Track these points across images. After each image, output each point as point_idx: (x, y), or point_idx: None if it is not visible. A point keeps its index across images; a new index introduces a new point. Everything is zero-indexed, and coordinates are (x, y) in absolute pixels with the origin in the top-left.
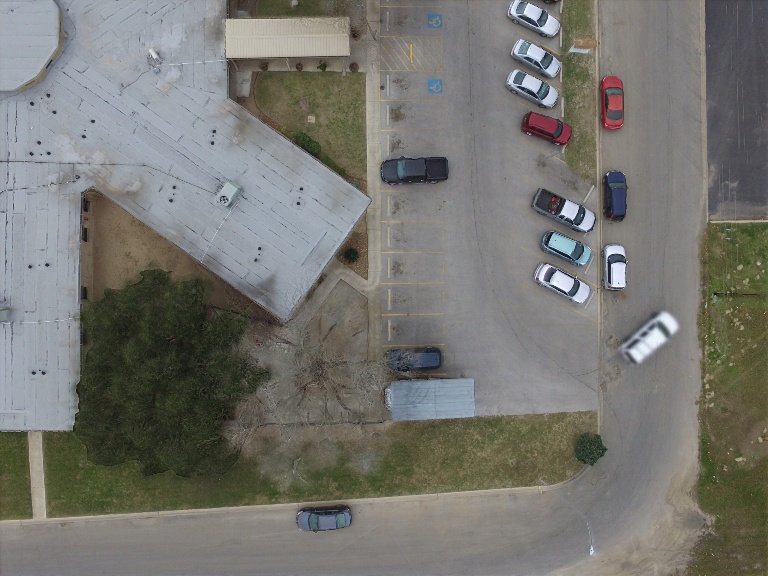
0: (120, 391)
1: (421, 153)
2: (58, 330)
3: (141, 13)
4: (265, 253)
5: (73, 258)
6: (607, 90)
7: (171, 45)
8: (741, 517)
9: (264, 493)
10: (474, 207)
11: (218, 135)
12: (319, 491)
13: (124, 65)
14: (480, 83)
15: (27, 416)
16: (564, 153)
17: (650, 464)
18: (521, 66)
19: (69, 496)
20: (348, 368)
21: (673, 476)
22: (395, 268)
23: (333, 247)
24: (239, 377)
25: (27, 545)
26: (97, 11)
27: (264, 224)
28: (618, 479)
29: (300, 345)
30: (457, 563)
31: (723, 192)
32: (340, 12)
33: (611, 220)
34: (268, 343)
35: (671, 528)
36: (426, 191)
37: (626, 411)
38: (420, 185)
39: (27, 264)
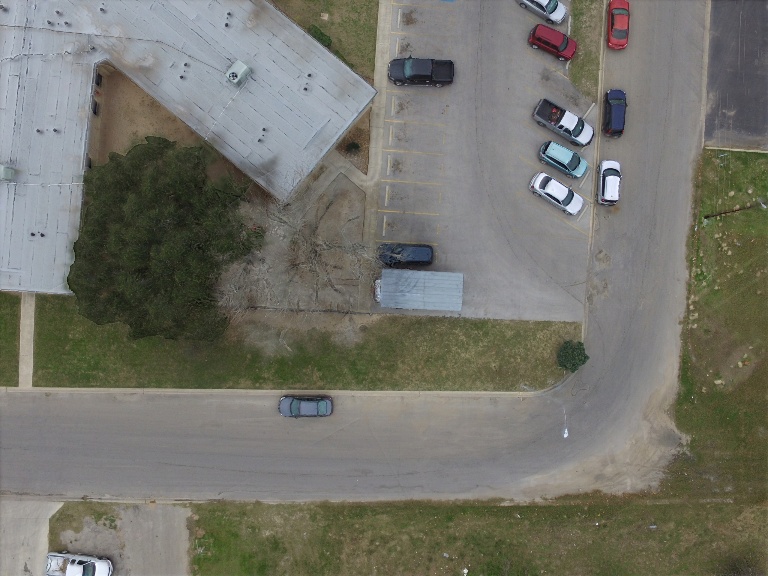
0: (117, 239)
1: (428, 57)
2: (60, 194)
3: None
4: (269, 135)
5: (81, 126)
6: (614, 10)
7: None
8: (716, 439)
9: (249, 377)
10: (476, 114)
11: (232, 18)
12: (303, 379)
13: None
14: None
15: (22, 276)
16: (568, 69)
17: (630, 379)
18: None
19: (56, 366)
20: (341, 259)
21: (652, 393)
22: (395, 166)
23: (336, 134)
24: (234, 236)
25: (11, 412)
26: None
27: (270, 106)
28: (598, 392)
29: (296, 233)
30: (434, 462)
31: (720, 120)
32: None
33: (609, 137)
34: (265, 228)
35: (647, 444)
36: (430, 94)
37: (610, 325)
38: (425, 88)
39: (35, 128)
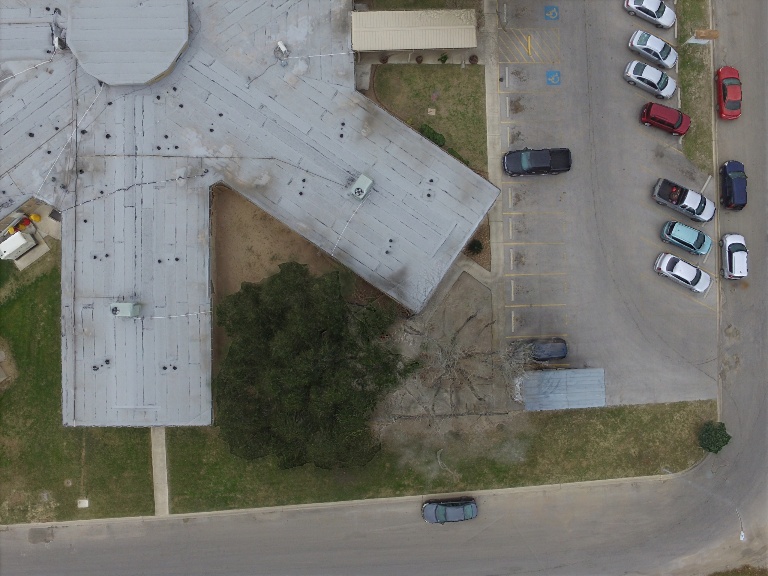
0: (275, 383)
1: (541, 144)
2: (188, 325)
3: (266, 6)
4: (396, 245)
5: (202, 252)
6: (725, 80)
7: (297, 38)
8: None
9: (389, 486)
10: (594, 198)
11: (346, 128)
12: (444, 483)
13: (250, 58)
14: (598, 74)
15: (158, 411)
16: (681, 143)
17: None
18: (638, 57)
19: (192, 492)
20: None
21: None
22: (517, 259)
23: (464, 238)
24: (391, 368)
25: (150, 542)
26: (222, 4)
27: (395, 216)
28: (738, 467)
29: (424, 337)
30: (581, 553)
31: None
32: (458, 4)
33: (729, 210)
34: (393, 335)
35: None
36: (546, 182)
37: (745, 399)
38: (541, 176)
39: (156, 259)
